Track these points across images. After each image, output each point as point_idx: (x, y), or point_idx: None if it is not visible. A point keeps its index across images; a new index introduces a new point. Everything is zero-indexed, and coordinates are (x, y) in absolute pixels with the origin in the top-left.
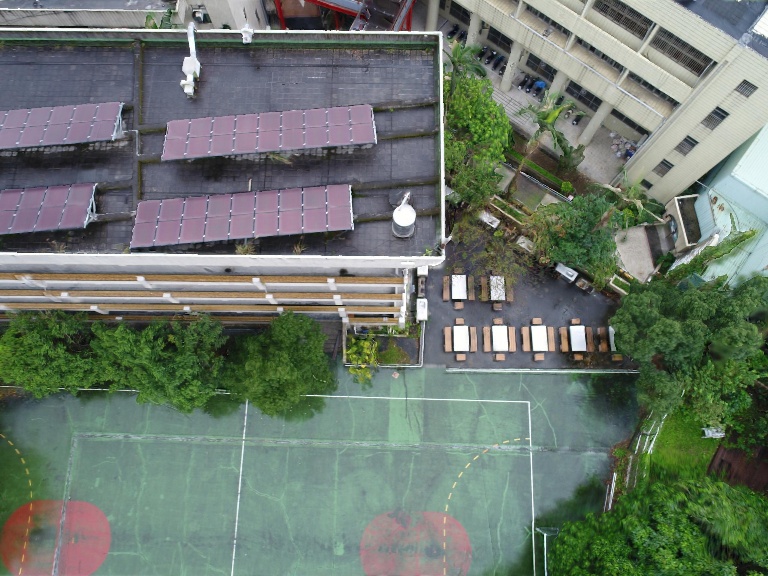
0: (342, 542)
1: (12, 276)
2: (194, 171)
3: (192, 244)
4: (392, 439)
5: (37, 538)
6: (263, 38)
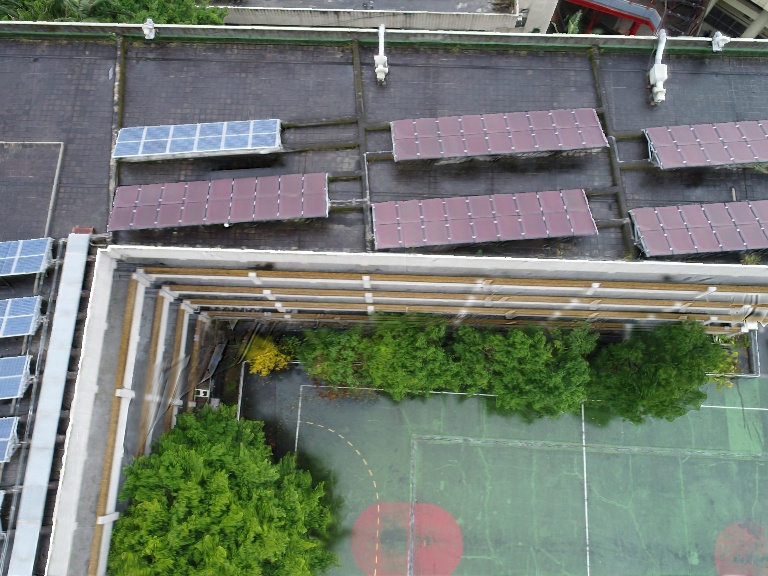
0: (696, 551)
1: (482, 280)
2: (673, 179)
3: (708, 253)
4: (734, 449)
5: (388, 540)
6: (724, 46)
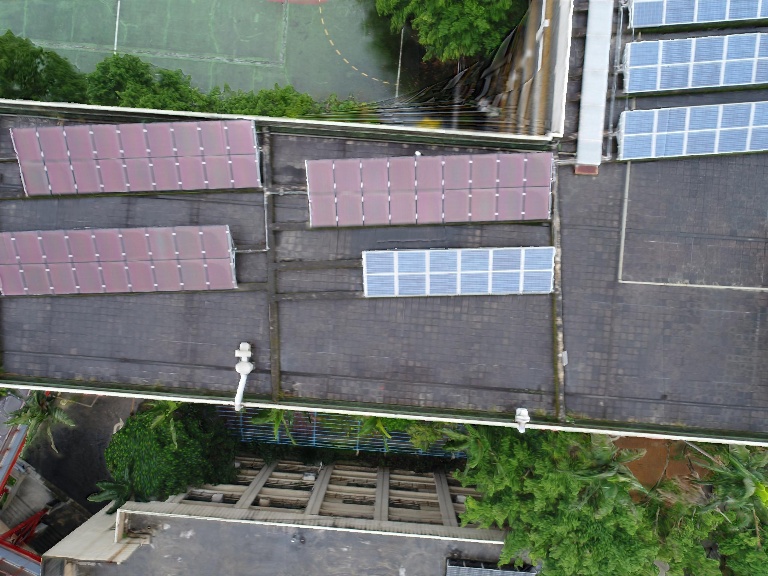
0: None
1: None
2: None
3: None
4: None
5: None
6: None
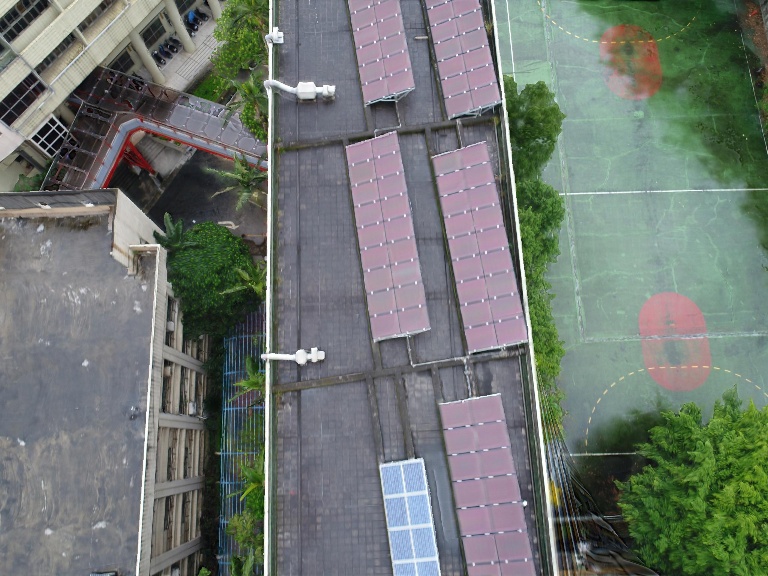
0: (633, 113)
1: None
2: None
3: None
4: (548, 81)
5: (676, 358)
6: None
